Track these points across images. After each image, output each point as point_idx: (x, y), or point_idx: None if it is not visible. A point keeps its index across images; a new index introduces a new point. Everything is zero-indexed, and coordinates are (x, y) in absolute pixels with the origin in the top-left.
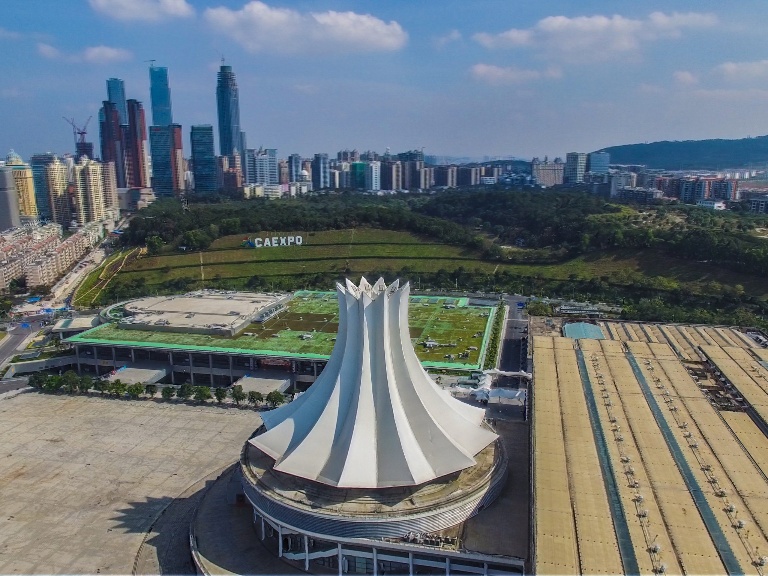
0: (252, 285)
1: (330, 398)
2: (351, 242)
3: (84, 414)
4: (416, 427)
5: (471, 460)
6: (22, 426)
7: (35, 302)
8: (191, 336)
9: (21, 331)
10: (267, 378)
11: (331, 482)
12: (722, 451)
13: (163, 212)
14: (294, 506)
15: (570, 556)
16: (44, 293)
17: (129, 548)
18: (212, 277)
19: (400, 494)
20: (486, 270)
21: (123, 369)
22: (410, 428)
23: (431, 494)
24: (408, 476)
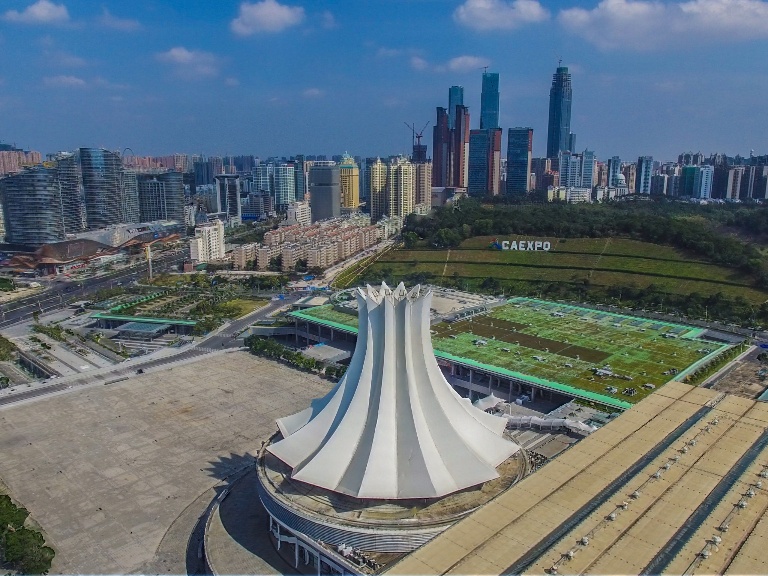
0: (486, 286)
1: (334, 395)
2: (602, 252)
3: (263, 376)
4: (401, 442)
5: (435, 491)
6: (218, 375)
7: (309, 280)
8: None
9: (280, 302)
10: None
11: (294, 472)
12: (738, 574)
13: (435, 210)
14: (265, 485)
15: None
16: (318, 273)
17: (201, 488)
18: (451, 274)
19: (356, 504)
20: (754, 300)
21: (320, 345)
22: (396, 442)
23: (382, 513)
24: (357, 487)
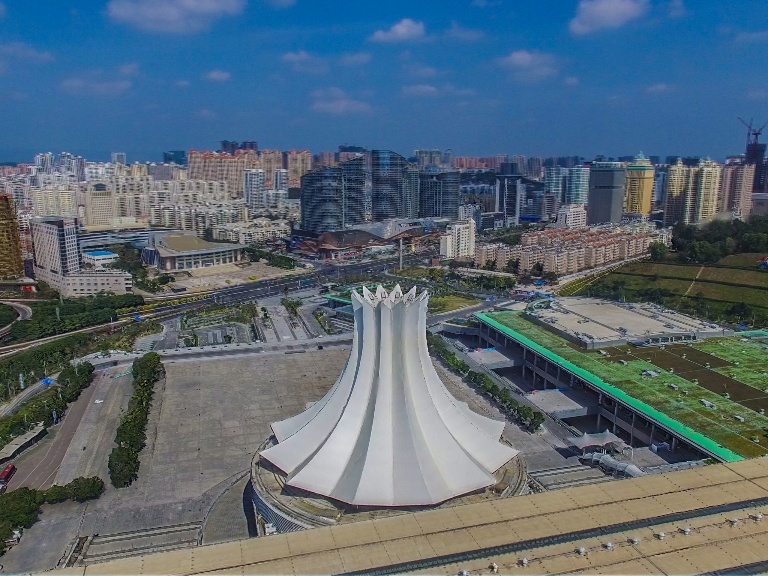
0: (734, 313)
1: None
2: None
3: None
4: (358, 444)
5: (354, 498)
6: None
7: (540, 285)
8: (555, 338)
9: None
10: (572, 399)
11: None
12: None
13: (710, 219)
14: None
15: (159, 573)
16: (552, 279)
17: None
18: (694, 295)
19: (300, 491)
20: None
21: (491, 350)
22: (355, 443)
23: (311, 506)
24: None
